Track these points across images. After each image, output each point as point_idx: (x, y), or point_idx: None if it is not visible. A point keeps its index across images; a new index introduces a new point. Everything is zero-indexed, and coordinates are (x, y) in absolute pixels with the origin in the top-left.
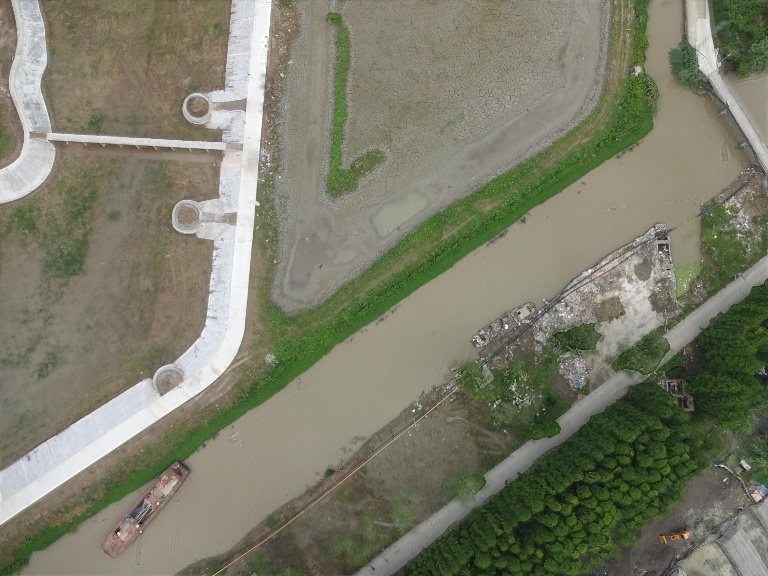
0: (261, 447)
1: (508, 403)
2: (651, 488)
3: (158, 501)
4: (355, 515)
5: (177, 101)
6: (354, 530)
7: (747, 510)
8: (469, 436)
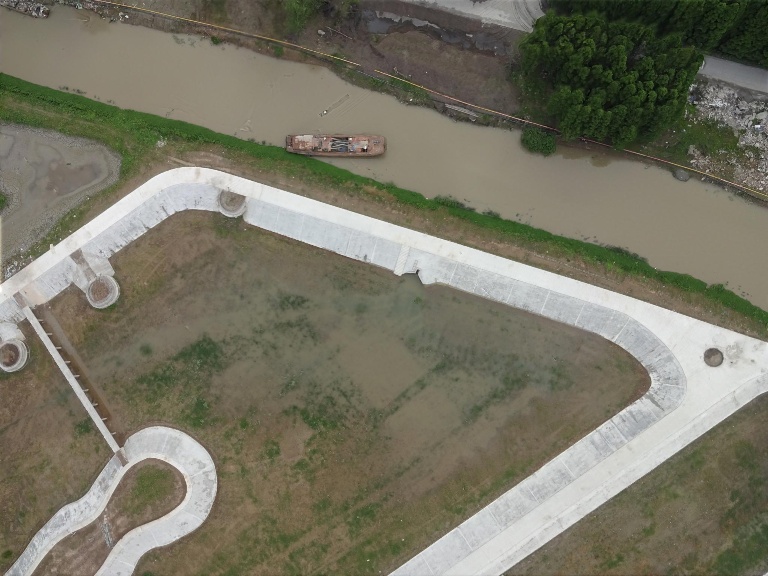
0: (239, 106)
1: None
2: None
3: (323, 140)
4: None
5: (21, 379)
6: None
7: None
8: None
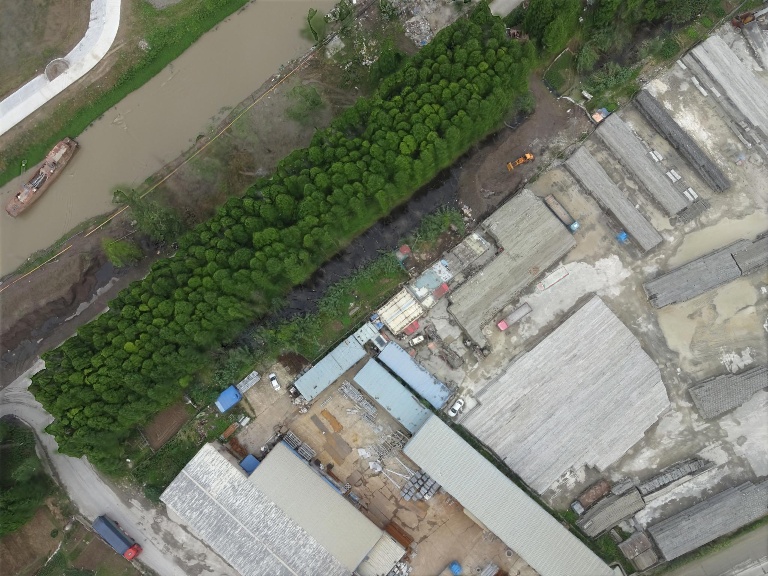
0: (143, 128)
1: (358, 64)
2: (469, 82)
3: (52, 169)
4: (222, 167)
5: None
6: (221, 179)
7: (592, 135)
8: (323, 95)
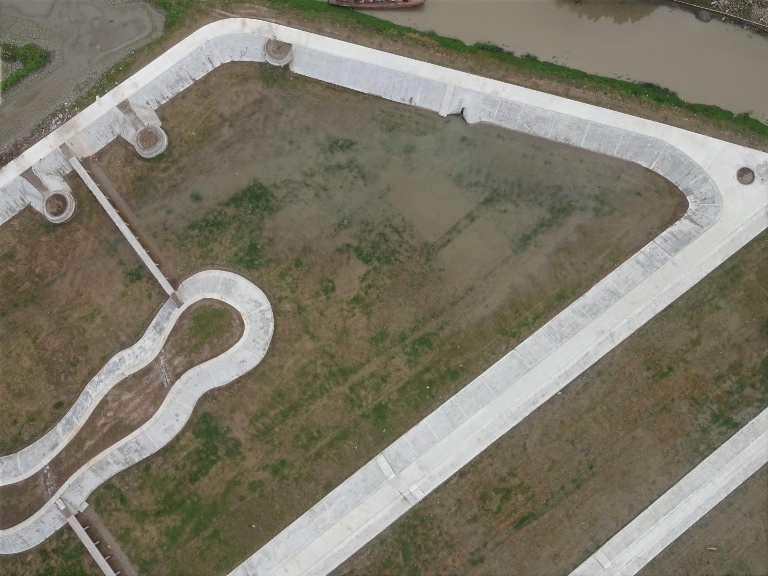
0: None
1: None
2: None
3: None
4: None
5: (68, 231)
6: None
7: None
8: None
